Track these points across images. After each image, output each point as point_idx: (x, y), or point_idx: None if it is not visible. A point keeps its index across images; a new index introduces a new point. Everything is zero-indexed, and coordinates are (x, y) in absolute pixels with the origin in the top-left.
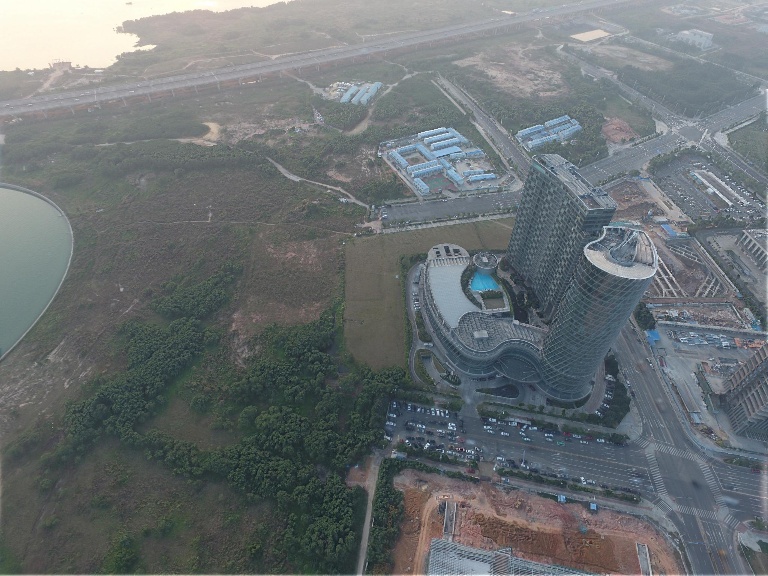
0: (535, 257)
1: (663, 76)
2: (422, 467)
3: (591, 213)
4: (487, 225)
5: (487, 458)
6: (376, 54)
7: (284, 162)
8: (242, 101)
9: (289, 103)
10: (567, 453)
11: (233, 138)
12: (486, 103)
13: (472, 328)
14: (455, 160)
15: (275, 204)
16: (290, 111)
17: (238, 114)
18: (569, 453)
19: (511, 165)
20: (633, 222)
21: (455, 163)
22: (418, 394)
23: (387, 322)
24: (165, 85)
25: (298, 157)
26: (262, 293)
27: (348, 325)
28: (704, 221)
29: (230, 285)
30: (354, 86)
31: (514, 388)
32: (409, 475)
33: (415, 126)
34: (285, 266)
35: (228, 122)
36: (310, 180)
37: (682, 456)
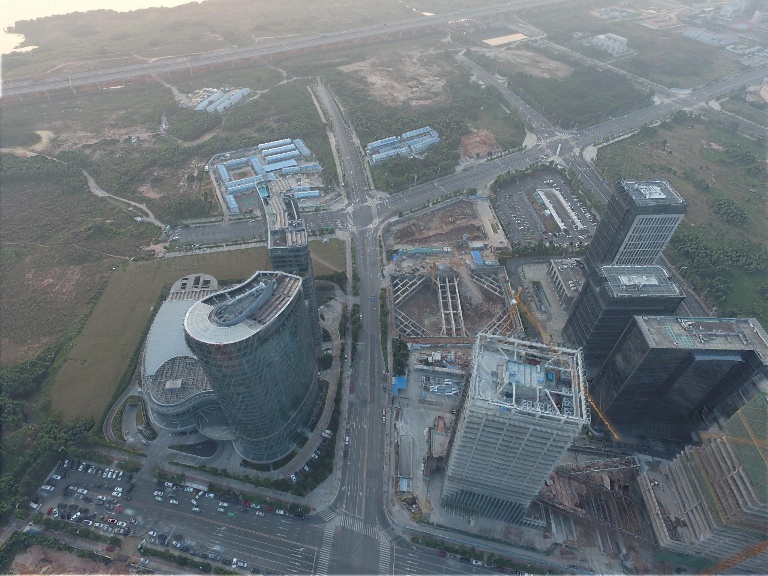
0: None
1: (553, 84)
2: (49, 544)
3: (275, 252)
4: None
5: (138, 532)
6: (262, 58)
7: (97, 176)
8: (92, 108)
9: (142, 110)
10: (234, 527)
11: (59, 148)
12: (349, 112)
13: (170, 376)
14: (286, 175)
15: (62, 223)
16: (138, 119)
17: (80, 122)
18: (236, 527)
19: None
20: (444, 248)
21: None
22: (90, 452)
23: (112, 362)
24: (11, 90)
25: (116, 170)
26: None
27: (66, 365)
28: (519, 248)
29: None
30: (219, 92)
31: (213, 445)
32: (35, 553)
33: (259, 137)
34: (32, 295)
35: (64, 130)
36: (116, 196)
37: (366, 533)
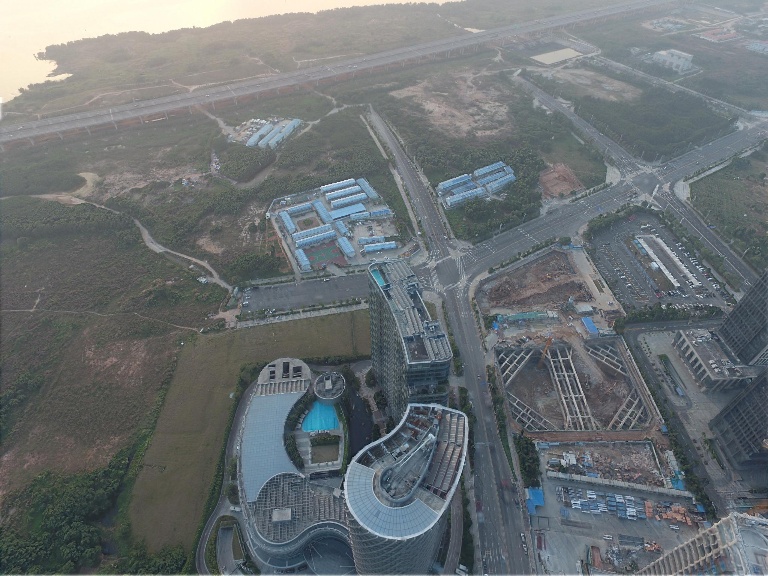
0: (389, 385)
1: (625, 109)
2: None
3: (414, 367)
4: (367, 316)
5: None
6: (308, 83)
7: (151, 226)
8: (136, 144)
9: (189, 146)
10: None
11: (106, 193)
12: (411, 146)
13: (275, 502)
14: (355, 222)
15: (119, 286)
16: (186, 157)
17: (125, 161)
18: None
19: (420, 229)
20: (548, 313)
21: (354, 226)
22: None
23: (195, 469)
24: (51, 127)
25: (171, 219)
26: (52, 421)
27: (143, 474)
28: None
29: (17, 409)
30: (268, 124)
31: None
32: None
33: (320, 177)
34: (96, 379)
35: (109, 172)
36: (174, 251)
37: None
